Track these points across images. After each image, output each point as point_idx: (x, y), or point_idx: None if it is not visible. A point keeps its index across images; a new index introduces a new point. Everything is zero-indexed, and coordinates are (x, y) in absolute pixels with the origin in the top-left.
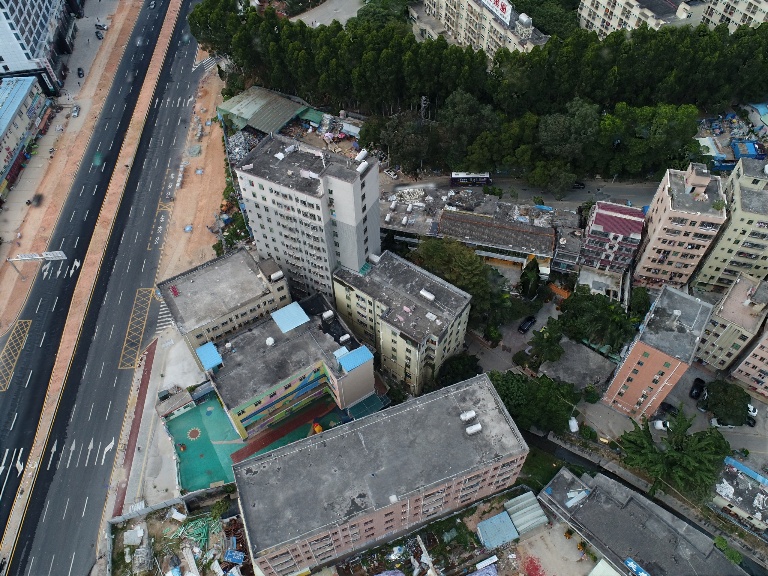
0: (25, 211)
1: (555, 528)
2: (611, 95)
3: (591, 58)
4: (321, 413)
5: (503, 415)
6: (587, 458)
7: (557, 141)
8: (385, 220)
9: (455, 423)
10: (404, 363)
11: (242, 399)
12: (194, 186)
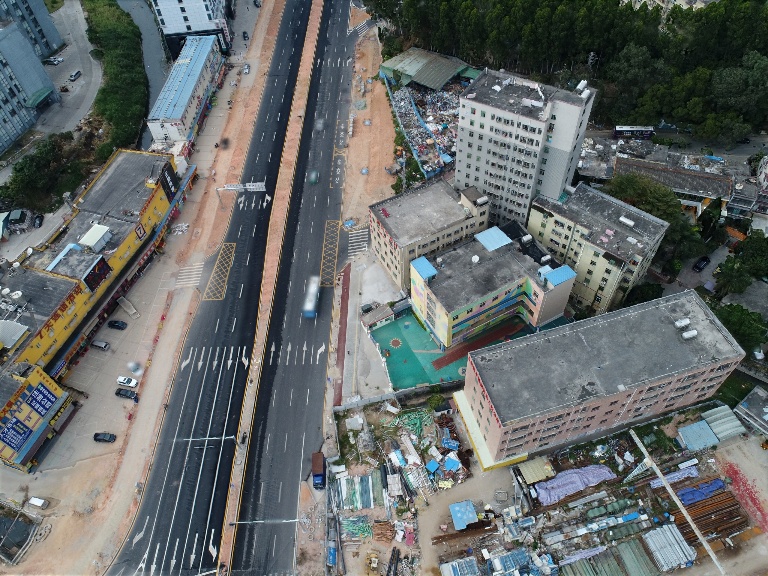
0: (214, 153)
1: (751, 440)
2: None
3: None
4: (511, 332)
5: (714, 325)
6: None
7: (732, 93)
8: None
9: (669, 330)
10: (598, 286)
11: (457, 305)
12: (364, 135)
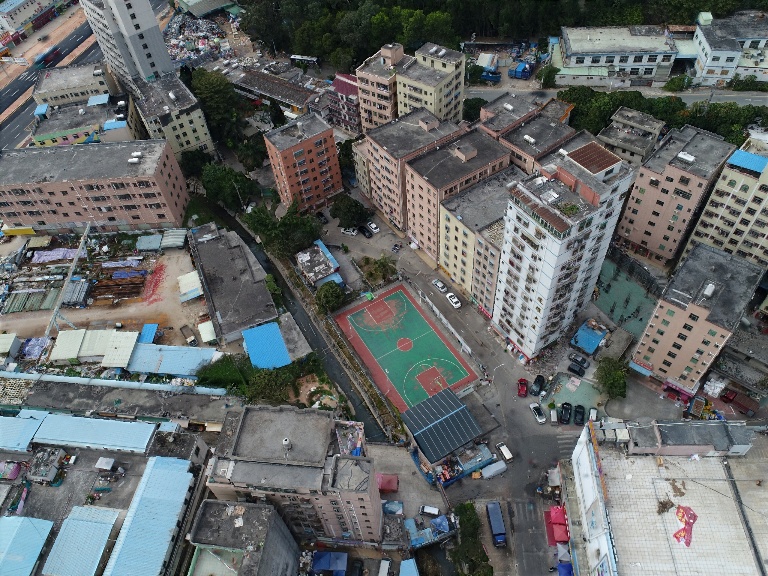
0: (35, 44)
1: None
2: (416, 8)
3: None
4: None
5: None
6: (250, 233)
7: (347, 31)
8: (212, 69)
9: (129, 158)
10: None
11: None
12: None
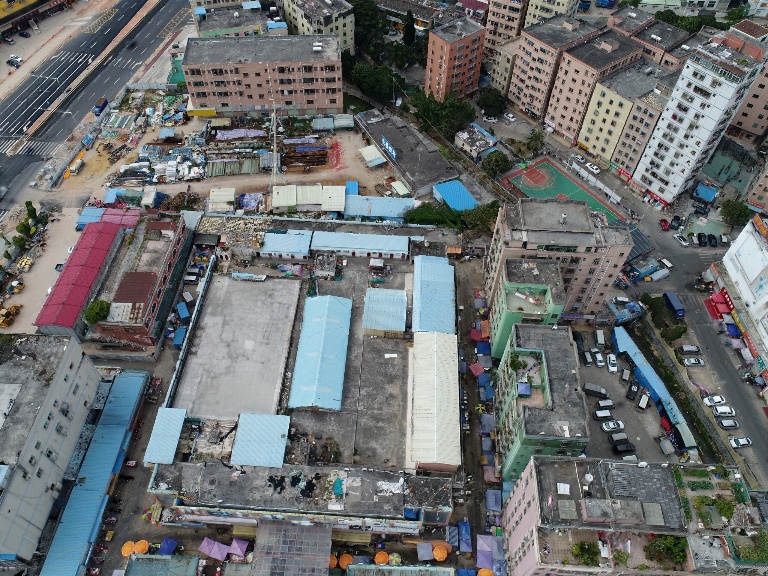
0: None
1: (359, 135)
2: None
3: None
4: None
5: (338, 50)
6: None
7: None
8: None
9: (310, 48)
10: None
11: None
12: None
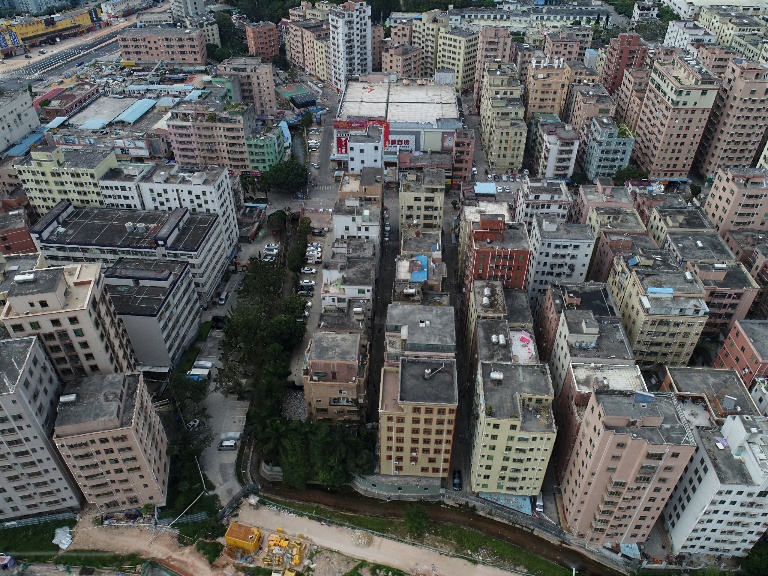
0: None
1: None
2: None
3: None
4: None
5: None
6: None
7: (290, 7)
8: None
9: None
10: None
11: None
12: None
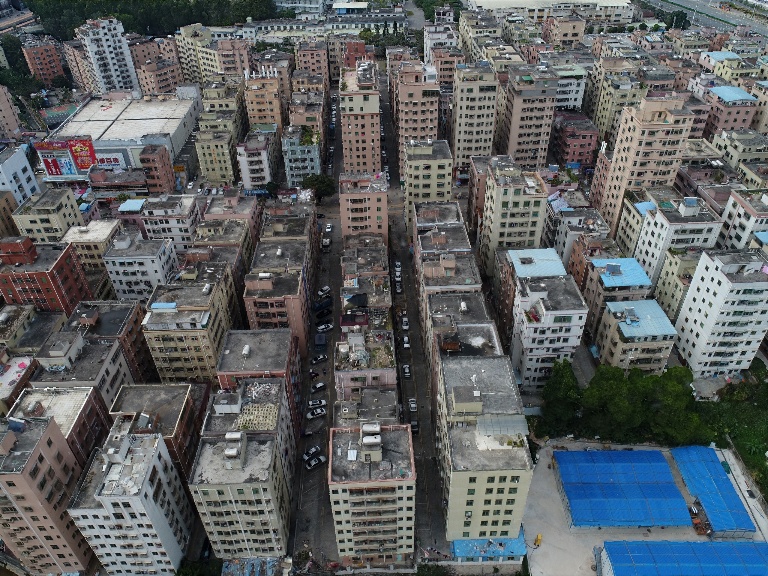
0: None
1: None
2: None
3: (110, 0)
4: None
5: None
6: None
7: None
8: None
9: None
10: None
11: None
12: None
